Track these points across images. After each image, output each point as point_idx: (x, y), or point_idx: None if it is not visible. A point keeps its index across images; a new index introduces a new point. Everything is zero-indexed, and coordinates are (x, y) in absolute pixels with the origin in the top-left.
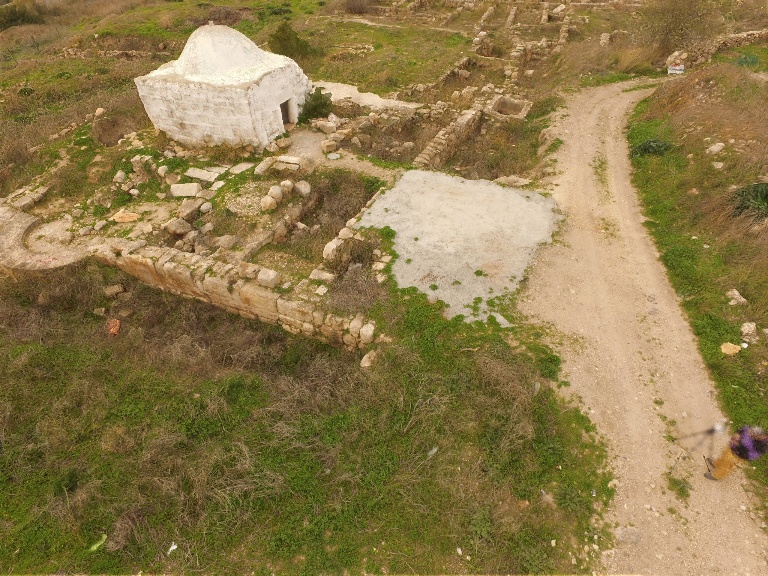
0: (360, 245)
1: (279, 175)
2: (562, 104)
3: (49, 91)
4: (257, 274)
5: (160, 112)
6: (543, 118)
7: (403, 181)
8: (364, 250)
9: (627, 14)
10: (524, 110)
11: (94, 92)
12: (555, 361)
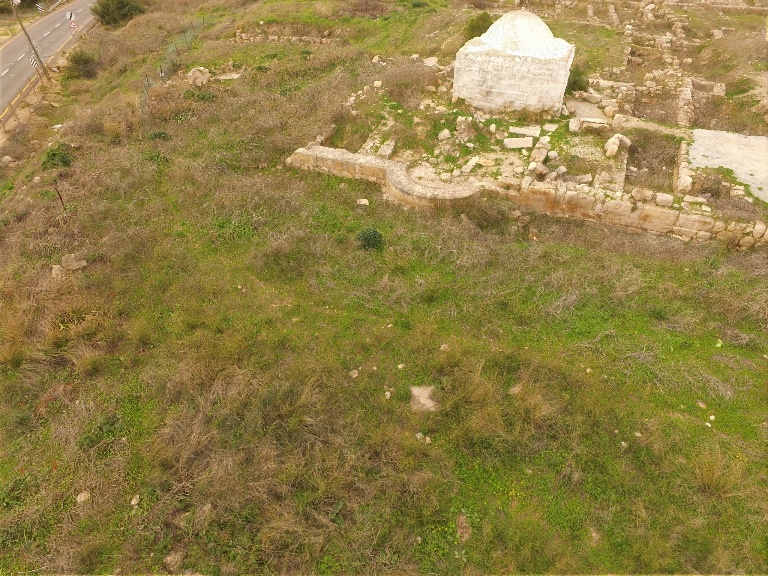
0: None
1: (595, 132)
2: (757, 84)
3: (286, 69)
4: (655, 197)
5: (469, 82)
6: (743, 95)
7: (699, 136)
8: (713, 183)
9: (715, 14)
10: (721, 89)
11: (323, 70)
12: None
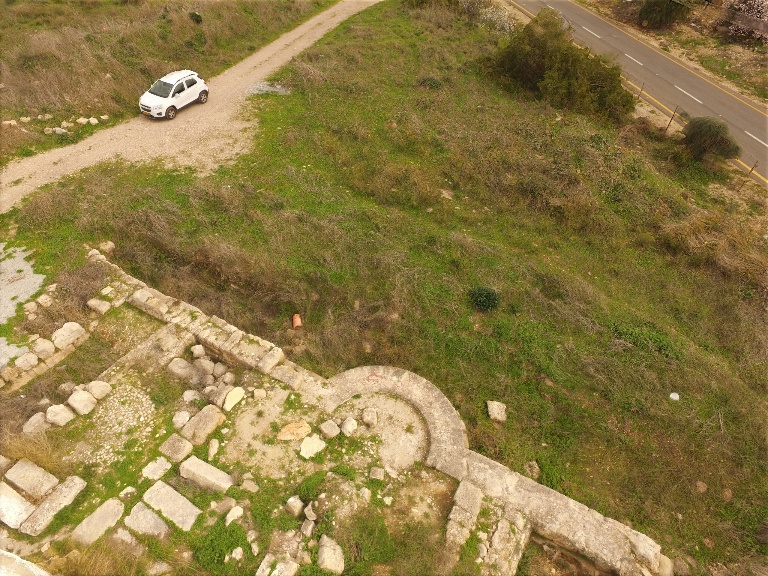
0: (40, 326)
1: None
2: None
3: None
4: (151, 298)
5: None
6: None
7: None
8: (41, 323)
9: None
10: None
11: None
12: (4, 213)
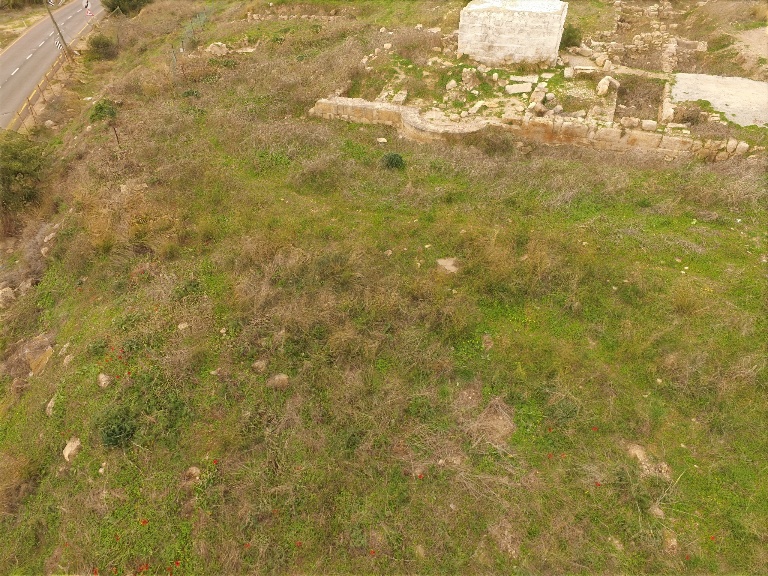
0: None
1: (587, 77)
2: (736, 39)
3: (300, 39)
4: (641, 123)
5: (473, 38)
6: (723, 50)
7: (681, 78)
8: (692, 113)
9: None
10: (703, 46)
11: (334, 40)
12: None
